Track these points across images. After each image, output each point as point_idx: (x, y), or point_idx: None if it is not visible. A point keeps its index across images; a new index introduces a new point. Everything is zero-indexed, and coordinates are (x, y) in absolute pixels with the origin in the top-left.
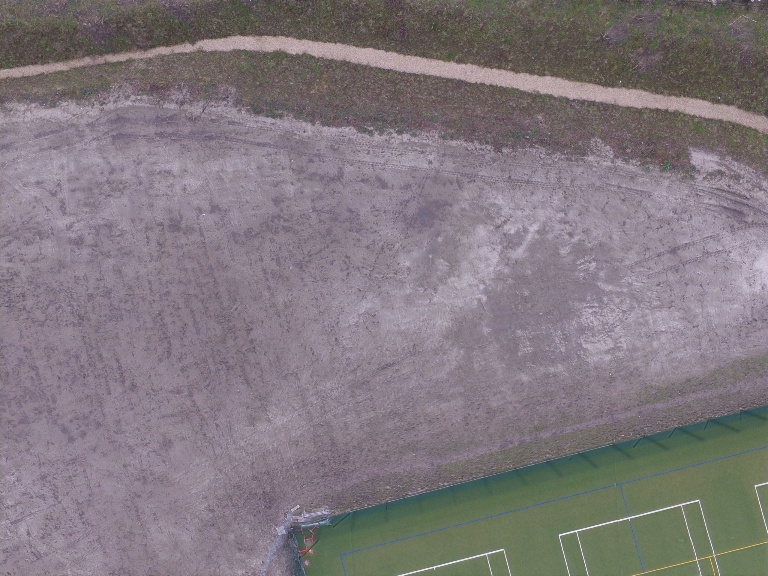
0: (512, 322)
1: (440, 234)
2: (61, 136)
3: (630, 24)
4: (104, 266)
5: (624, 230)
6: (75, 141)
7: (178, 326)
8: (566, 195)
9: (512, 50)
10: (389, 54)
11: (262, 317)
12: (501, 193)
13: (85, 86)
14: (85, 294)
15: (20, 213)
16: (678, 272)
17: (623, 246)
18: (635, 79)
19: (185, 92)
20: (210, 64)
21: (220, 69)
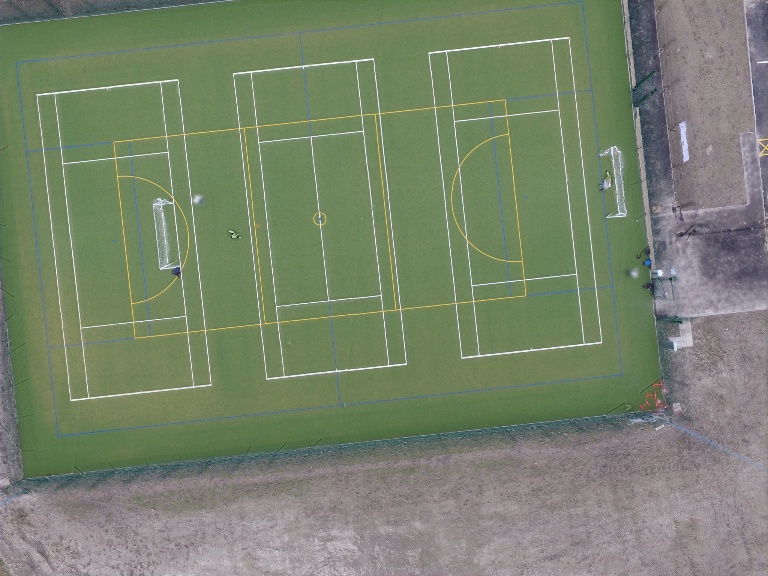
0: None
1: None
2: None
3: None
4: None
5: None
6: None
7: None
8: None
9: None
10: None
11: None
12: None
13: None
14: None
15: None
16: None
17: None
18: None
19: None
20: None
21: None
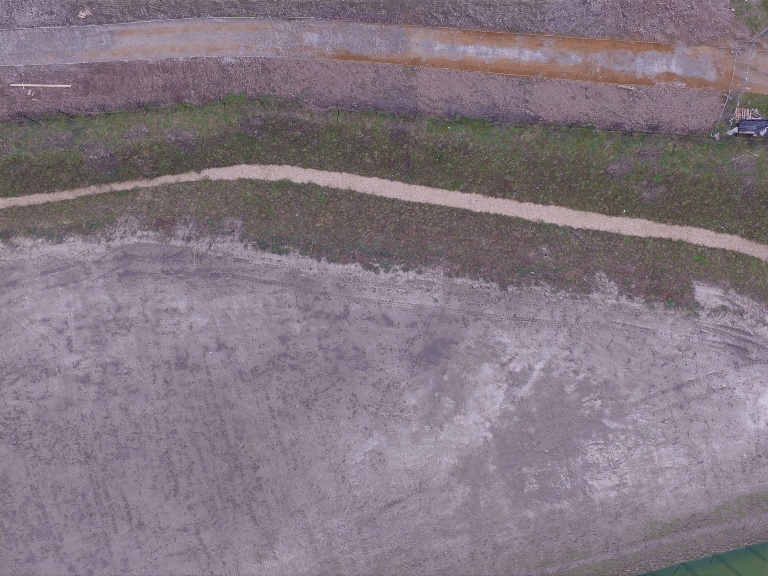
0: (518, 459)
1: (446, 372)
2: (68, 273)
3: (634, 158)
4: (111, 404)
5: (629, 367)
6: (82, 278)
7: (185, 464)
8: (571, 333)
9: (516, 181)
10: (394, 183)
11: (269, 455)
12: (506, 331)
13: (91, 220)
14: (92, 432)
15: (27, 350)
16: (683, 409)
17: (628, 383)
18: (639, 209)
19: (191, 226)
20: (216, 195)
21: (226, 200)
